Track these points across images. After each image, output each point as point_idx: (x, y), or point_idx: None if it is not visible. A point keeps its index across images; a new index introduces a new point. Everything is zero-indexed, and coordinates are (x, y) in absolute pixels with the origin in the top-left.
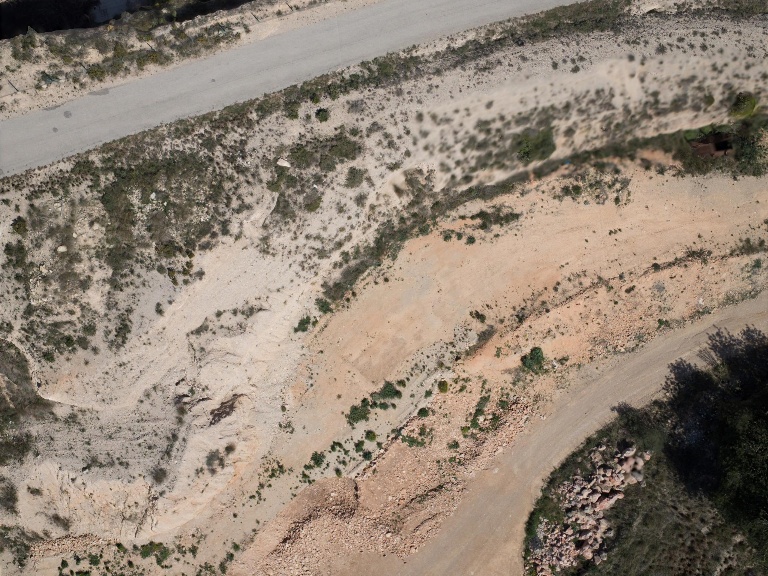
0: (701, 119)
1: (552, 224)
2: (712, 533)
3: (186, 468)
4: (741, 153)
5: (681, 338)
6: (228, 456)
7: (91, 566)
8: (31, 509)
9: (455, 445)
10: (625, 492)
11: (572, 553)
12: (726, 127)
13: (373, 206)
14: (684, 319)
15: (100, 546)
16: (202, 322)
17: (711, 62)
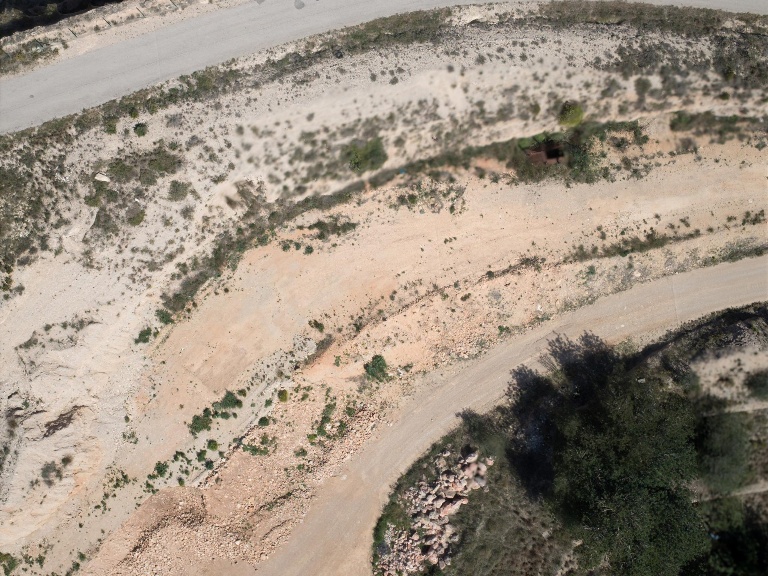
0: (532, 127)
1: (388, 233)
2: (552, 537)
3: (19, 480)
4: (574, 161)
5: (522, 344)
6: (66, 467)
7: None
8: None
9: (302, 453)
10: (469, 497)
11: (418, 558)
12: (559, 135)
13: (207, 218)
14: (524, 325)
15: None
16: (30, 336)
17: (531, 72)
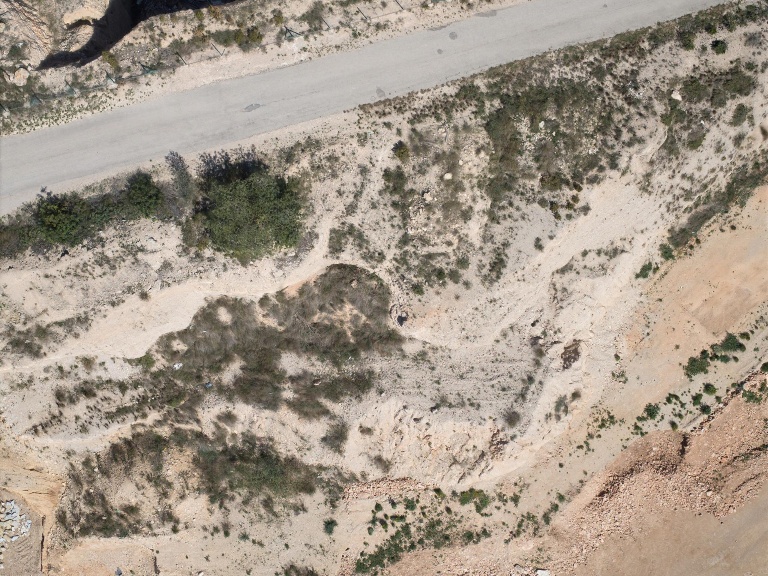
0: None
1: None
2: None
3: (538, 412)
4: None
5: None
6: (571, 403)
7: (406, 511)
8: (356, 449)
9: None
10: None
11: None
12: None
13: None
14: None
15: (417, 491)
16: (568, 261)
17: None
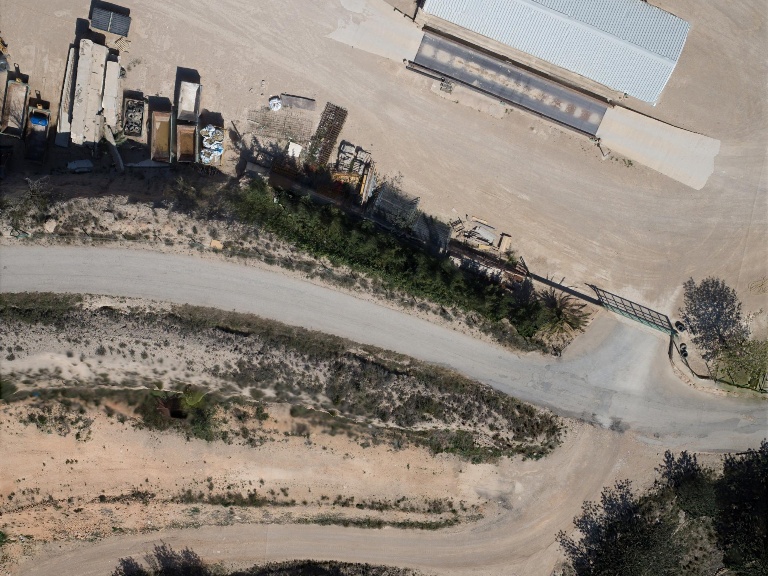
0: None
1: (15, 443)
2: None
3: None
4: None
5: (133, 542)
6: None
7: None
8: None
9: None
10: None
11: None
12: None
13: None
14: (136, 529)
15: None
16: None
17: None
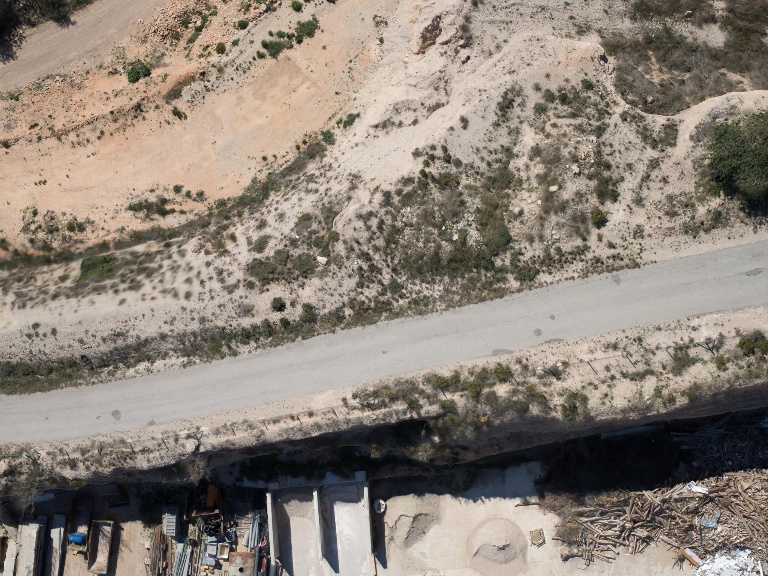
0: None
1: (98, 197)
2: None
3: None
4: None
5: (2, 83)
6: None
7: None
8: None
9: None
10: None
11: None
12: None
13: None
14: None
15: None
16: None
17: None
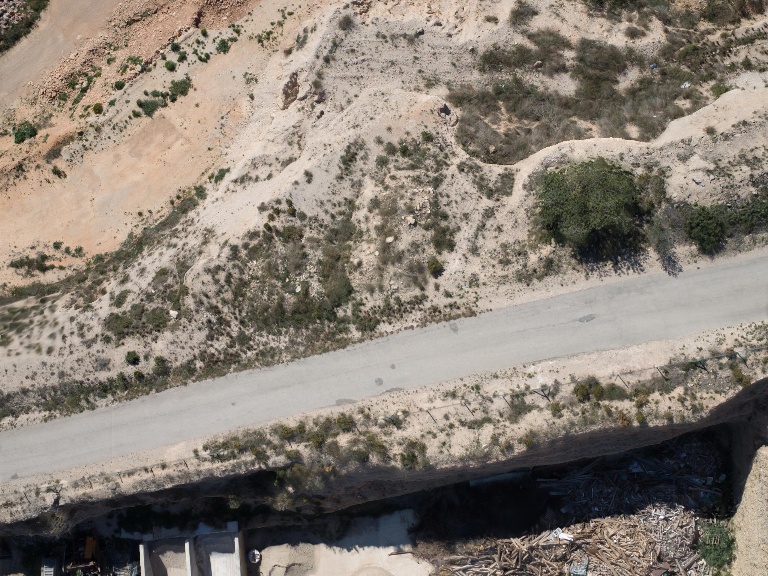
0: None
1: None
2: None
3: (322, 31)
4: None
5: None
6: None
7: None
8: (504, 5)
9: (109, 61)
10: None
11: None
12: None
13: None
14: None
15: None
16: None
17: None
